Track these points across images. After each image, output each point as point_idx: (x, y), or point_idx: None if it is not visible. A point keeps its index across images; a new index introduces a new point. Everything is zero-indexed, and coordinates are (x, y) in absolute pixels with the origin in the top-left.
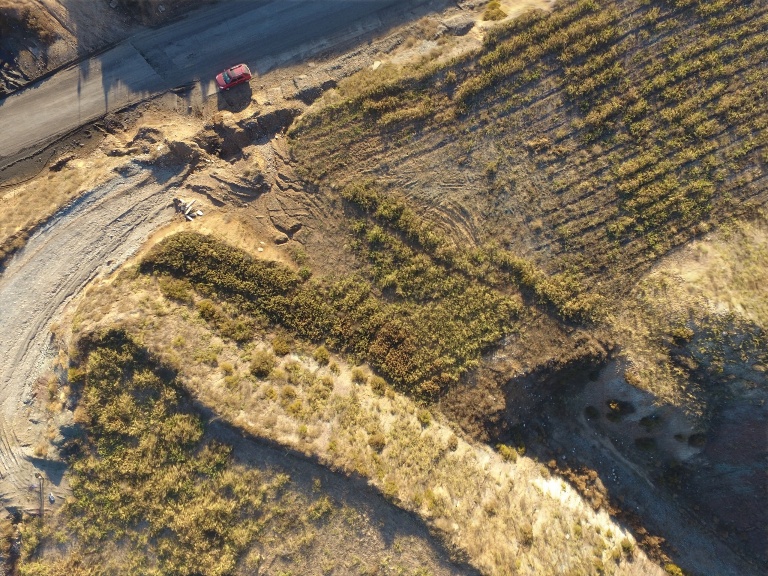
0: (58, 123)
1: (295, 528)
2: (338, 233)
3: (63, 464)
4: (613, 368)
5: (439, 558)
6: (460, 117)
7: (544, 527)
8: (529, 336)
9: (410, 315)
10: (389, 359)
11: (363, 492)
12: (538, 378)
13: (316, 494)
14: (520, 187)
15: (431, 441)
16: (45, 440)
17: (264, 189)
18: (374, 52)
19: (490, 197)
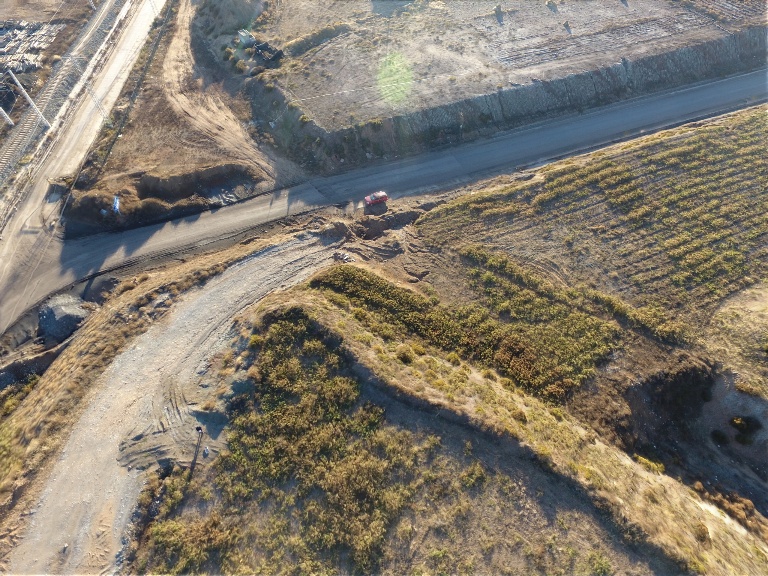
0: (252, 220)
1: (448, 496)
2: (458, 277)
3: (225, 419)
4: (722, 384)
5: (611, 538)
6: (538, 213)
7: (717, 534)
8: (634, 352)
9: (526, 331)
10: (513, 365)
11: (515, 458)
12: (654, 389)
13: (468, 458)
14: (593, 252)
15: (569, 430)
16: (213, 397)
17: (399, 252)
18: (469, 190)
19: (572, 257)
